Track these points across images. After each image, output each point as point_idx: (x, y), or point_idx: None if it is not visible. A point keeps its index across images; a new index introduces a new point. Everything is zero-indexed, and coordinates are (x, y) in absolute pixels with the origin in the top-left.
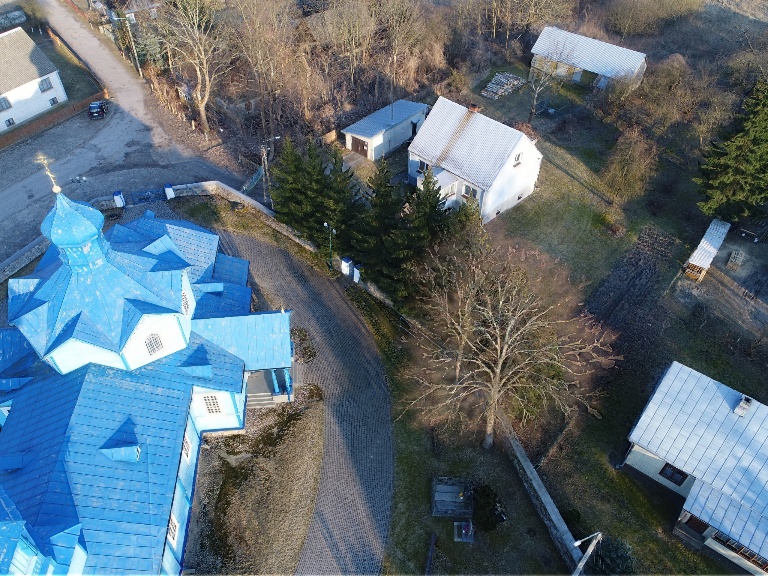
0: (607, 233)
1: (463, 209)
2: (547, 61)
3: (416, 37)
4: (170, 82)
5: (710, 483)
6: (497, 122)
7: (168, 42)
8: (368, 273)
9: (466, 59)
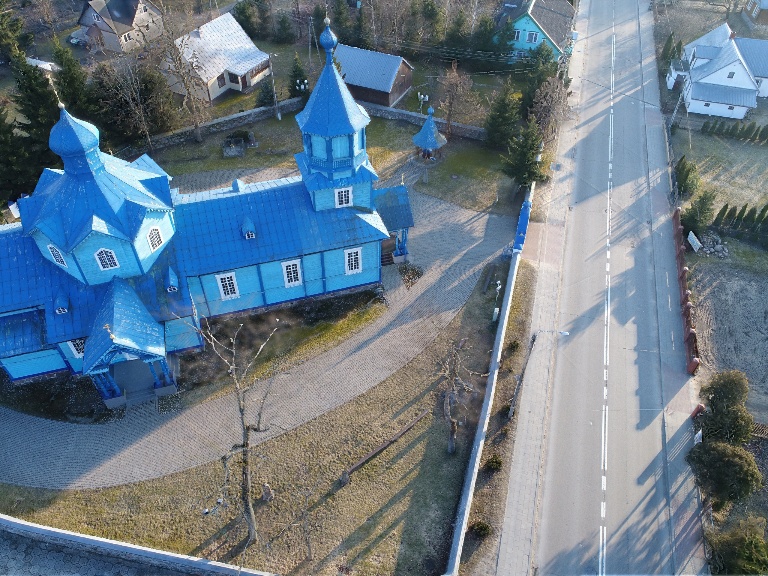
0: (7, 105)
1: (58, 51)
2: None
3: None
4: None
5: (229, 66)
6: None
7: None
8: None
9: None
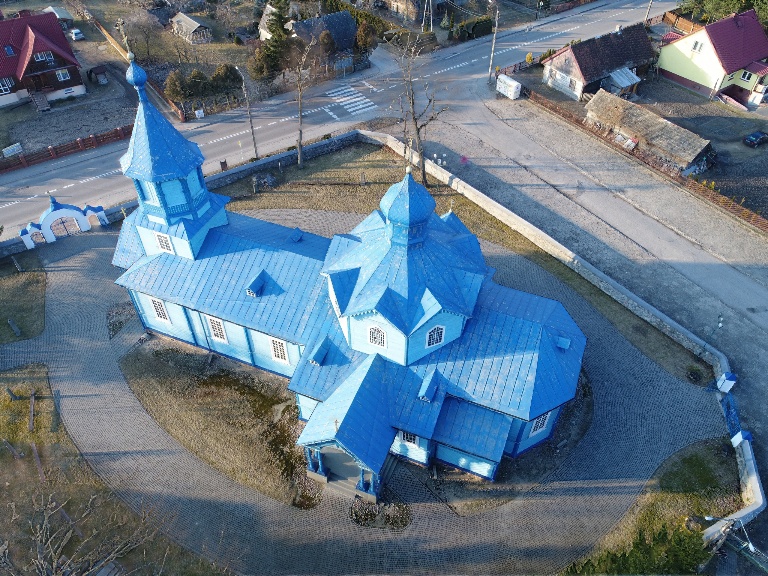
0: None
1: None
2: None
3: None
4: None
5: None
6: None
7: None
8: None
9: None
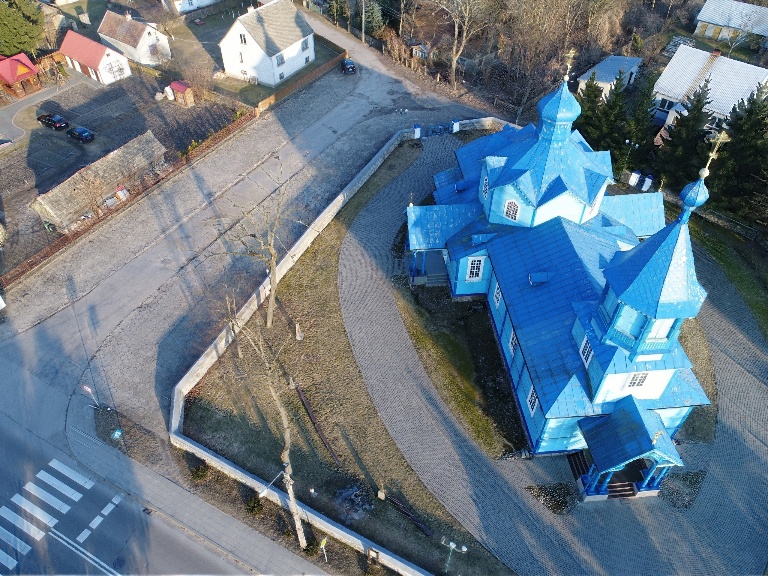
0: None
1: None
2: (746, 20)
3: (611, 4)
4: (404, 43)
5: None
6: (742, 63)
7: (439, 3)
8: (667, 179)
9: (639, 26)
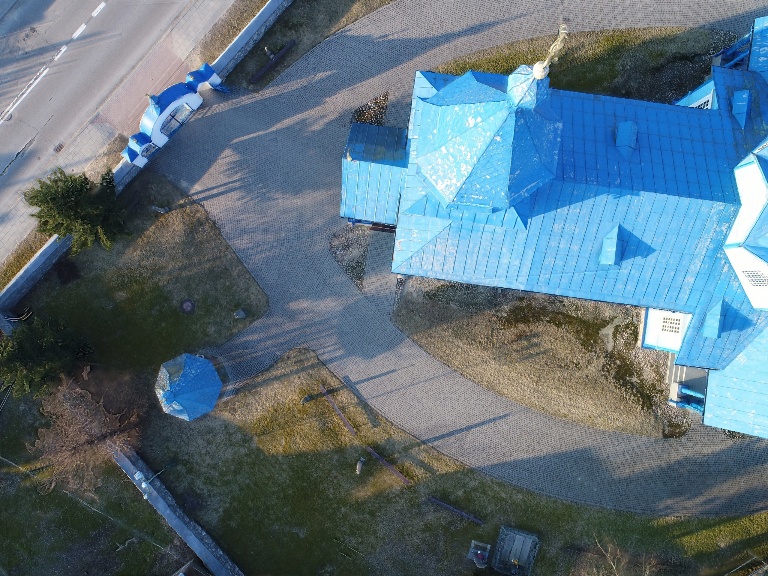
0: None
1: None
2: None
3: None
4: None
5: None
6: None
7: None
8: None
9: None
